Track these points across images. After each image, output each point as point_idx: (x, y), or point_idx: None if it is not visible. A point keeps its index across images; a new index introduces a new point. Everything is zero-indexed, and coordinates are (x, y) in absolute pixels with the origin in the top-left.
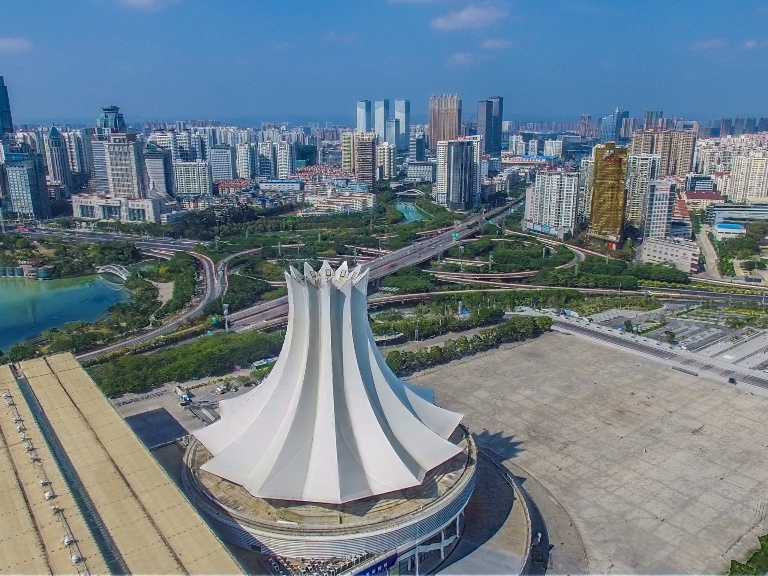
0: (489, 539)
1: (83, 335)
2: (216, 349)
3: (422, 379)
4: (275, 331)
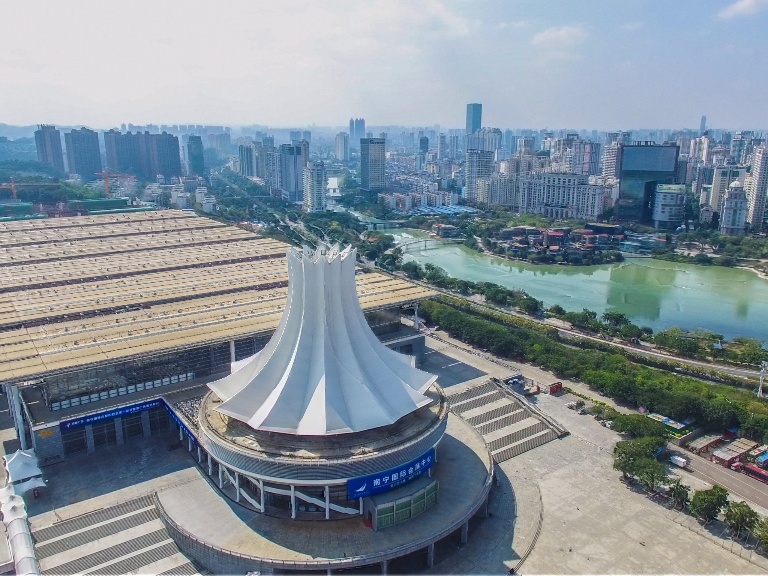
0: (253, 529)
1: (688, 341)
2: (641, 380)
3: (710, 547)
4: (761, 414)
